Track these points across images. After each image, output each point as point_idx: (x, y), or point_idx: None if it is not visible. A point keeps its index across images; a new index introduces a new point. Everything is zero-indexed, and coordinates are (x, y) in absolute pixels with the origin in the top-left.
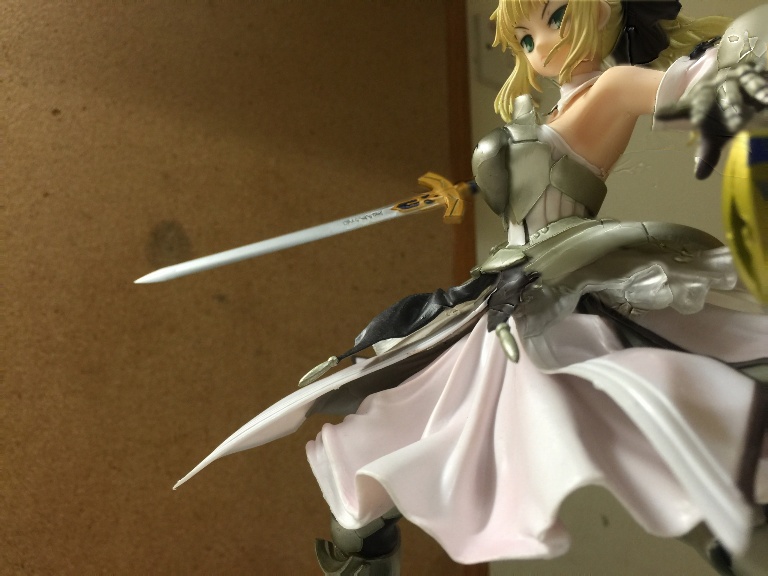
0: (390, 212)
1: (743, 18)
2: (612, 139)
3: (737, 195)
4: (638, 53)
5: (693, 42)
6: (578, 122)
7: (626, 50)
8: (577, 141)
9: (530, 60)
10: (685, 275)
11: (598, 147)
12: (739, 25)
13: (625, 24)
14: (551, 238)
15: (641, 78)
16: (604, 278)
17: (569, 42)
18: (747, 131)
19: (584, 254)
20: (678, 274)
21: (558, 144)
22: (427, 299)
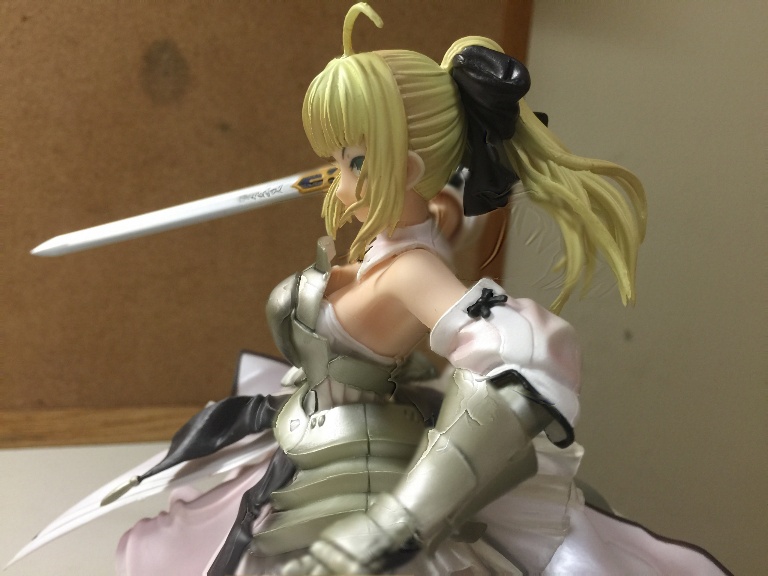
0: (290, 190)
1: (470, 372)
2: (406, 332)
3: (546, 408)
4: (472, 201)
5: (546, 193)
6: (365, 312)
7: (461, 190)
8: (364, 332)
9: None
10: (405, 568)
11: (389, 339)
12: (468, 375)
13: (459, 161)
14: (311, 453)
15: (422, 302)
16: None
17: (367, 205)
18: (525, 404)
19: (298, 538)
20: (396, 568)
21: (339, 336)
22: (245, 405)
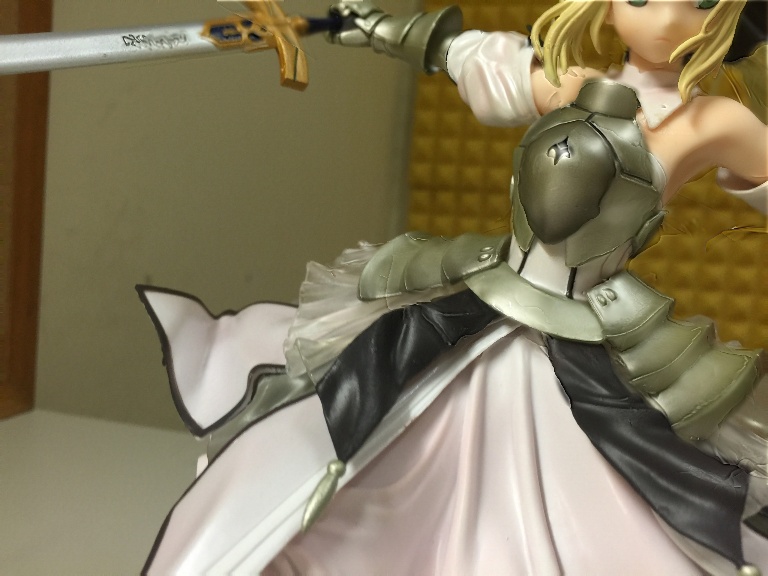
0: (199, 42)
1: None
2: None
3: (714, 250)
4: None
5: None
6: (679, 161)
7: None
8: (668, 184)
9: (626, 17)
10: None
11: (673, 191)
12: None
13: None
14: (641, 327)
15: (766, 142)
16: (726, 423)
17: (706, 40)
18: None
19: (729, 402)
20: None
21: (660, 190)
22: (403, 321)
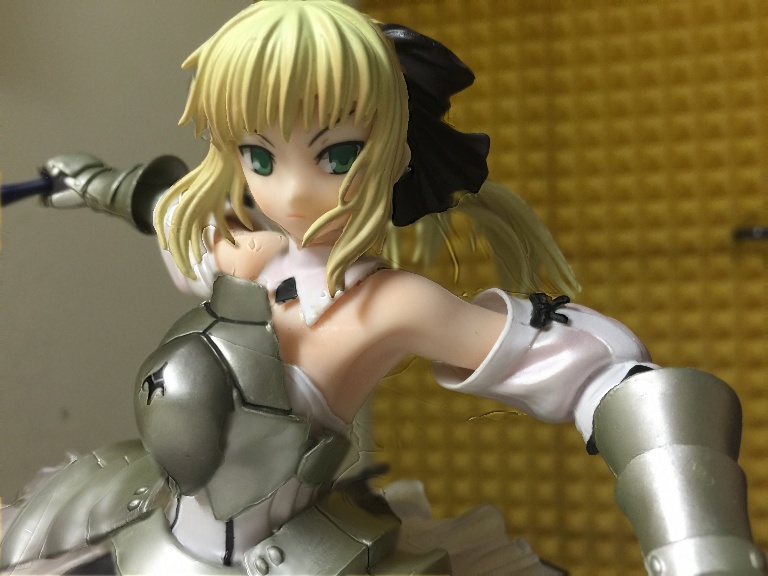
0: None
1: (670, 370)
2: None
3: (477, 432)
4: (406, 208)
5: None
6: (347, 365)
7: None
8: (339, 395)
9: (255, 188)
10: None
11: (360, 397)
12: (661, 375)
13: None
14: None
15: (459, 327)
16: None
17: (351, 211)
18: None
19: None
20: None
21: (317, 411)
22: None
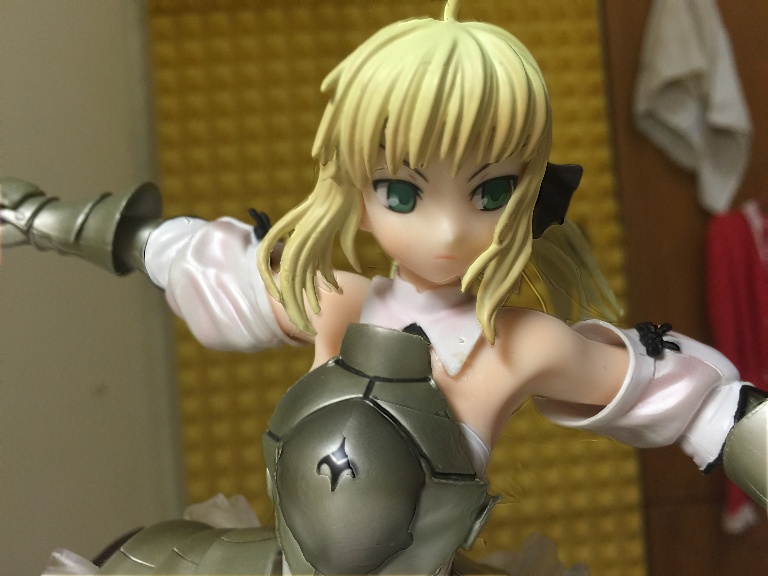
0: None
1: None
2: None
3: None
4: None
5: None
6: (497, 415)
7: None
8: None
9: (389, 227)
10: None
11: None
12: None
13: None
14: None
15: (592, 364)
16: None
17: None
18: None
19: None
20: None
21: (484, 469)
22: None
